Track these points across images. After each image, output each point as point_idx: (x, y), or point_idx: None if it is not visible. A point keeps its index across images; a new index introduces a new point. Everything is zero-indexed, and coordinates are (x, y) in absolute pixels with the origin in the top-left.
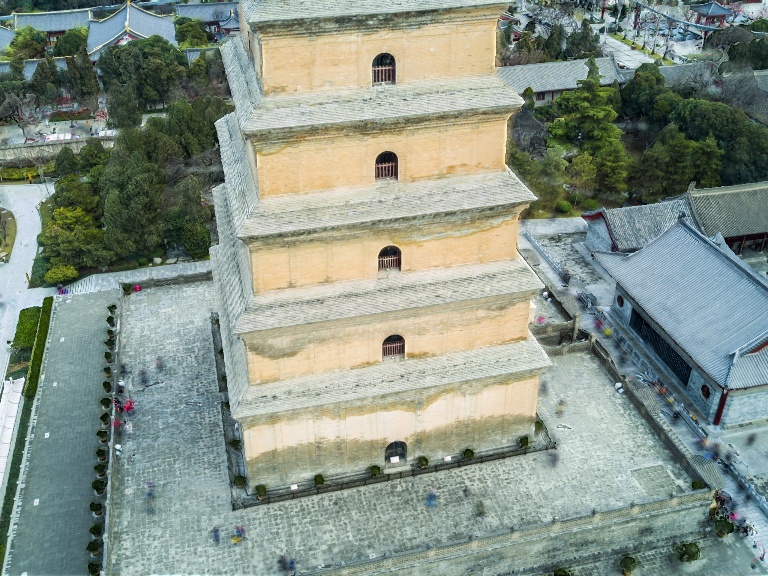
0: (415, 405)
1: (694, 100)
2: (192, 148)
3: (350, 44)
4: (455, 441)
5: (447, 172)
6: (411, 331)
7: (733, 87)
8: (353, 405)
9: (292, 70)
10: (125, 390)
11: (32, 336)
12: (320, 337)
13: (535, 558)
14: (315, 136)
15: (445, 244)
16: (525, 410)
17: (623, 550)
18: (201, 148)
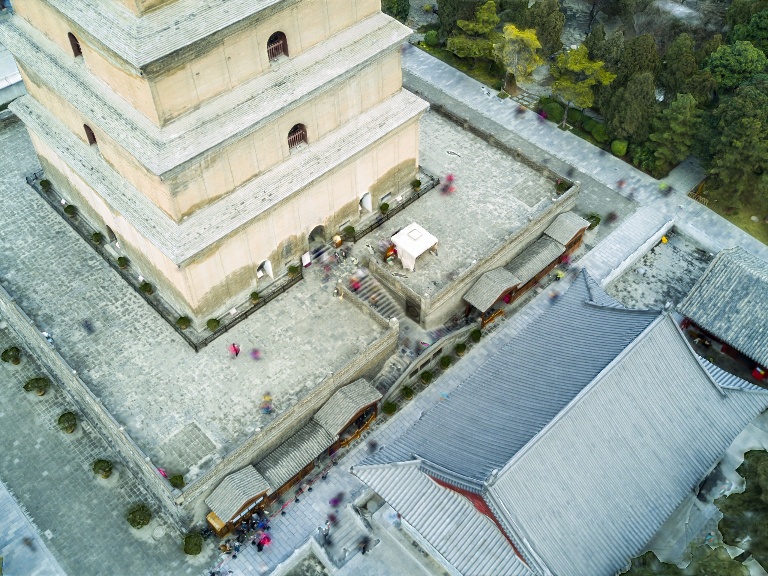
0: None
1: None
2: None
3: None
4: None
5: None
6: None
7: None
8: None
9: None
10: None
11: None
12: None
13: None
14: None
15: None
16: (184, 293)
17: (125, 461)
18: None
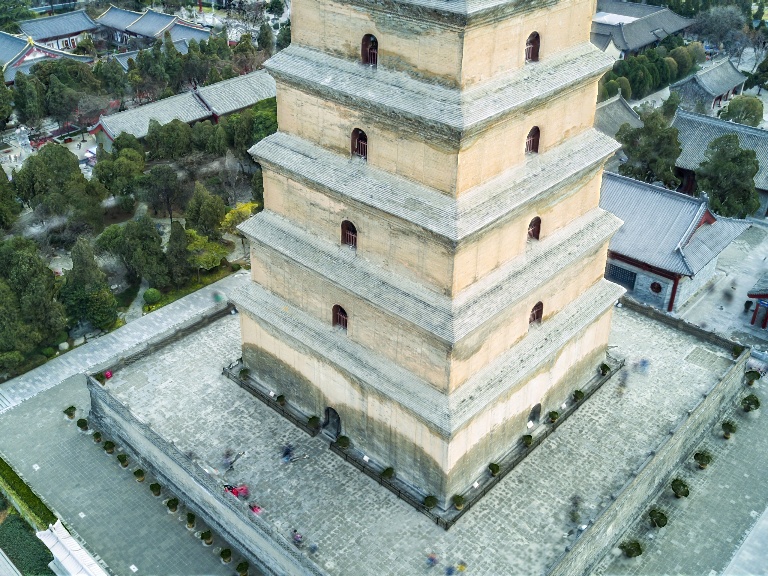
0: (550, 364)
1: None
2: (6, 215)
3: (516, 26)
4: (566, 388)
5: (564, 137)
6: (548, 294)
7: None
8: (517, 382)
9: (479, 60)
10: (213, 477)
11: None
12: (496, 324)
13: (677, 454)
14: (498, 122)
15: (565, 205)
16: (603, 340)
17: (714, 421)
18: None
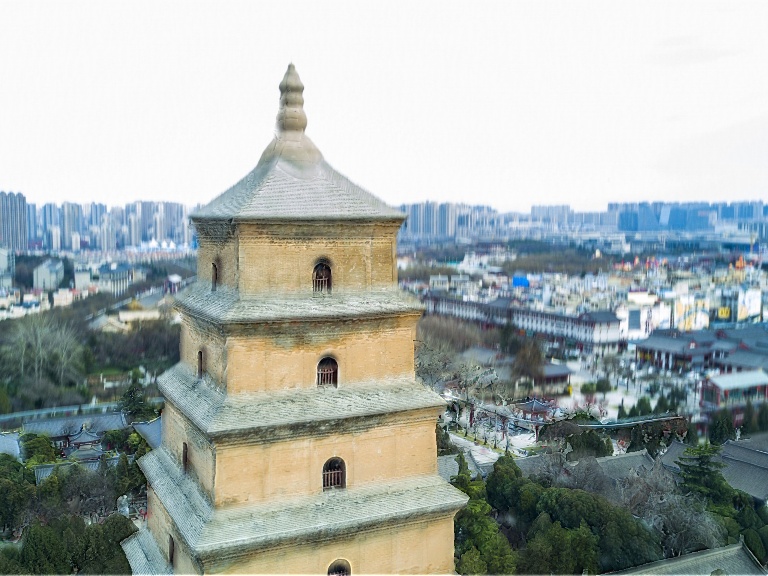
0: None
1: (557, 489)
2: (47, 575)
3: (302, 450)
4: None
5: None
6: None
7: (583, 475)
8: None
9: (244, 479)
10: None
11: None
12: None
13: None
14: (267, 548)
15: None
16: None
17: None
18: (57, 574)
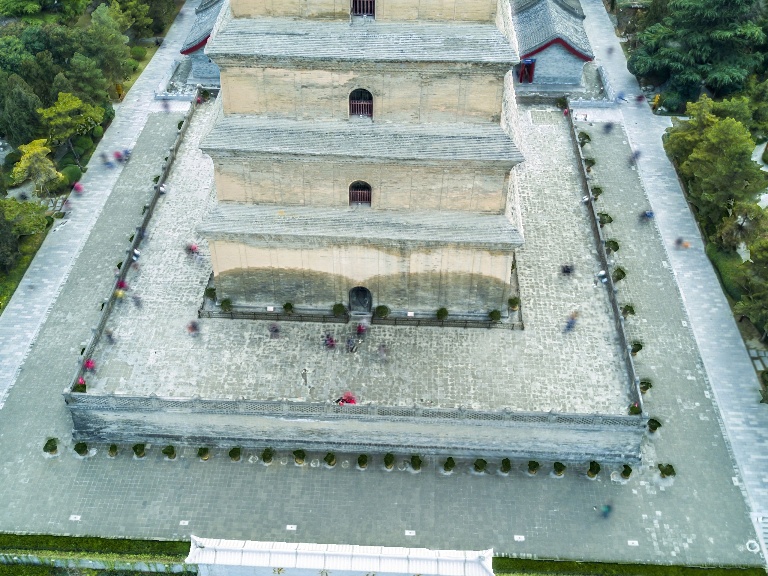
0: None
1: None
2: None
3: None
4: None
5: None
6: None
7: None
8: None
9: None
10: None
11: (23, 569)
12: None
13: None
14: None
15: None
16: None
17: None
18: None
